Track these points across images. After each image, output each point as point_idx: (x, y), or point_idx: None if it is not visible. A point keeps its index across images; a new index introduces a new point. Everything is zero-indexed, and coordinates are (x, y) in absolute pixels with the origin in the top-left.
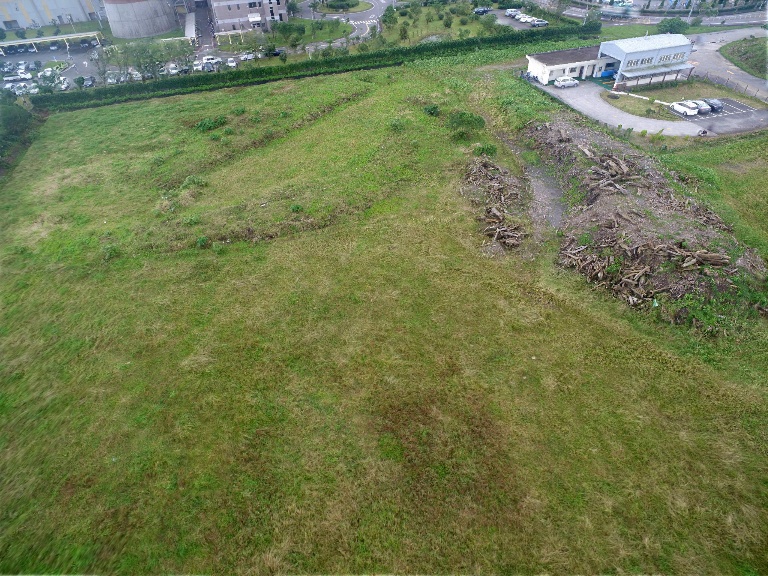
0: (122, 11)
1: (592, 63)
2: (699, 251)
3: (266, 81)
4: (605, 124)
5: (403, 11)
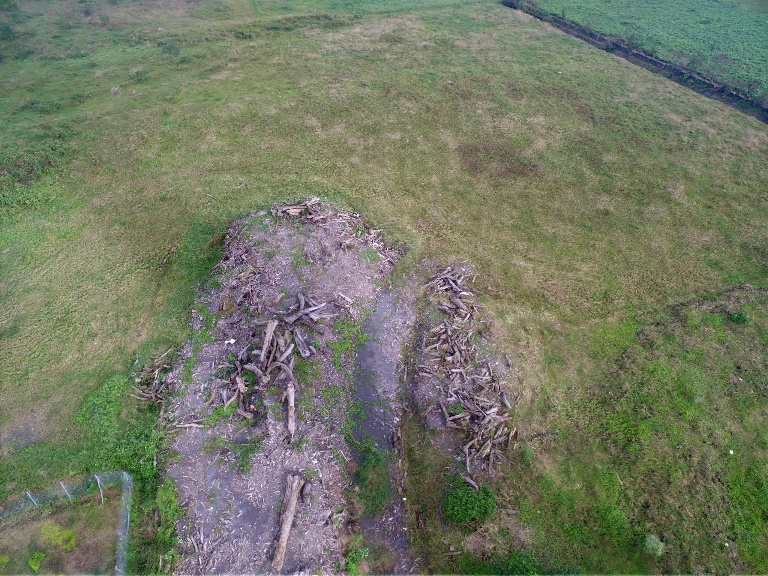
0: None
1: None
2: (295, 209)
3: None
4: None
5: None
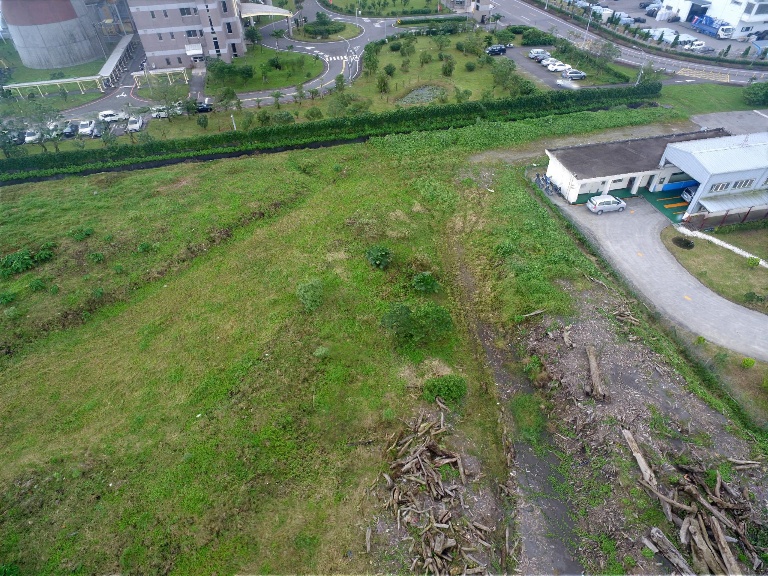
0: (26, 35)
1: (650, 173)
2: None
3: (166, 160)
4: (672, 328)
5: (395, 45)
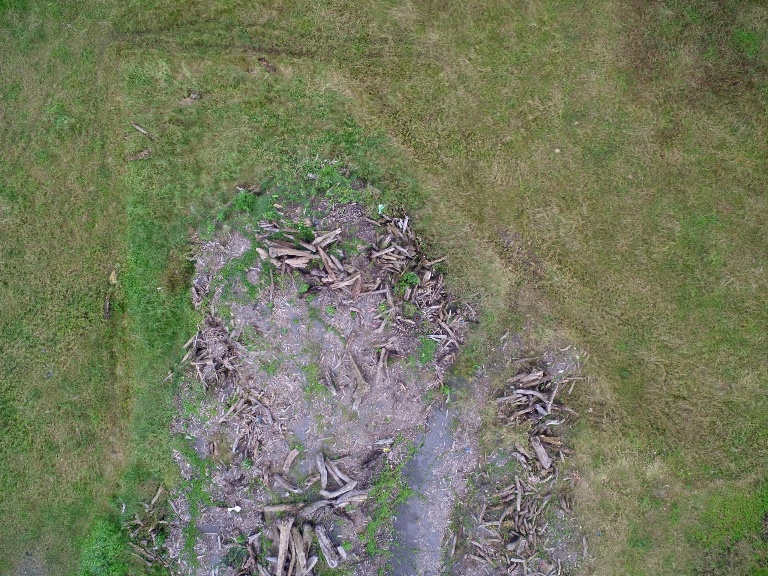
0: None
1: None
2: (299, 261)
3: None
4: None
5: None
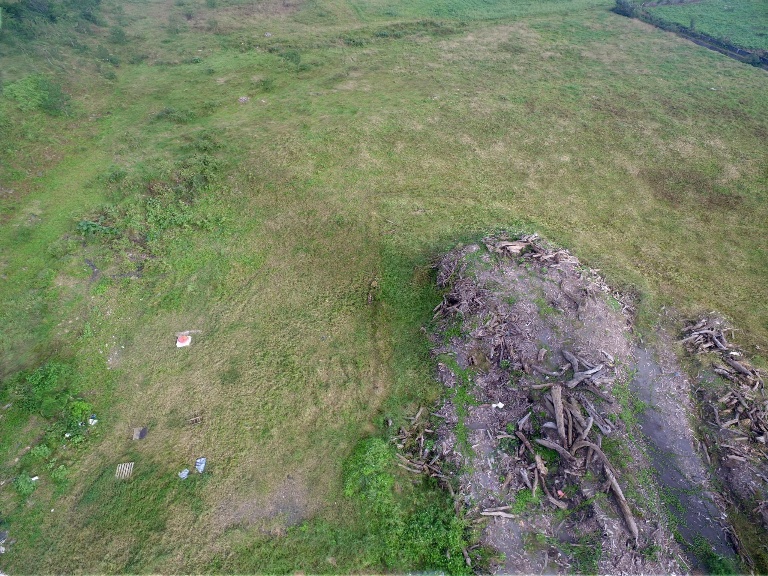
0: None
1: None
2: (516, 246)
3: None
4: None
5: None
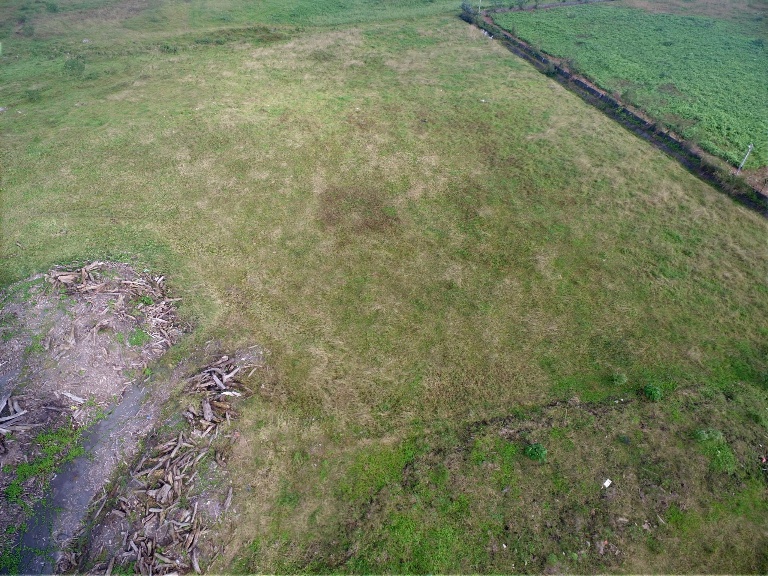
0: None
1: None
2: (67, 276)
3: None
4: None
5: None
